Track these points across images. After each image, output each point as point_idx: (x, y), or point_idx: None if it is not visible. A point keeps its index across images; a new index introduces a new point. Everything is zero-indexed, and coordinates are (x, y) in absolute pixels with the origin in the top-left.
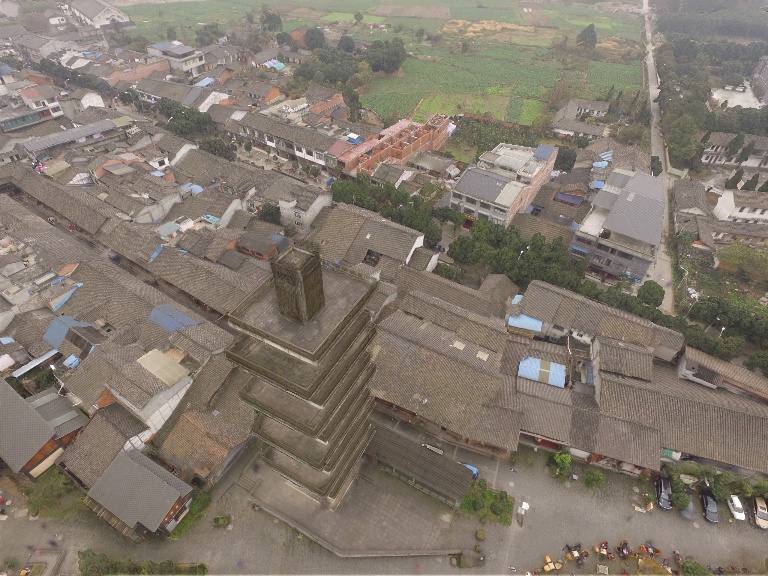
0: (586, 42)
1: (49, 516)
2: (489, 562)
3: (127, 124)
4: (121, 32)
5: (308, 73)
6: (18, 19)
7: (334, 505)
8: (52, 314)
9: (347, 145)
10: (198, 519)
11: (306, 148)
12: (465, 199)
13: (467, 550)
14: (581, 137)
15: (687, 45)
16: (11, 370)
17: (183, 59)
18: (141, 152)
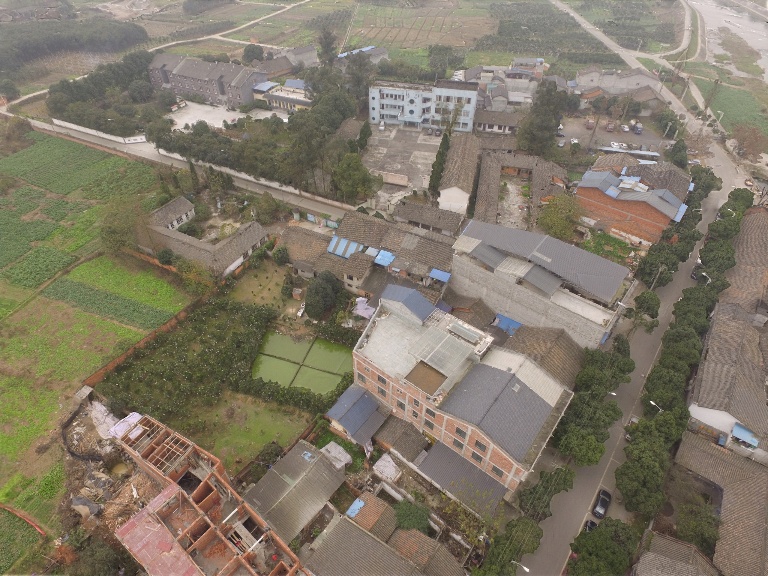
0: None
1: None
2: None
3: None
4: None
5: None
6: None
7: None
8: None
9: None
10: None
11: None
12: None
13: None
14: (278, 253)
15: (73, 88)
16: None
17: None
18: None
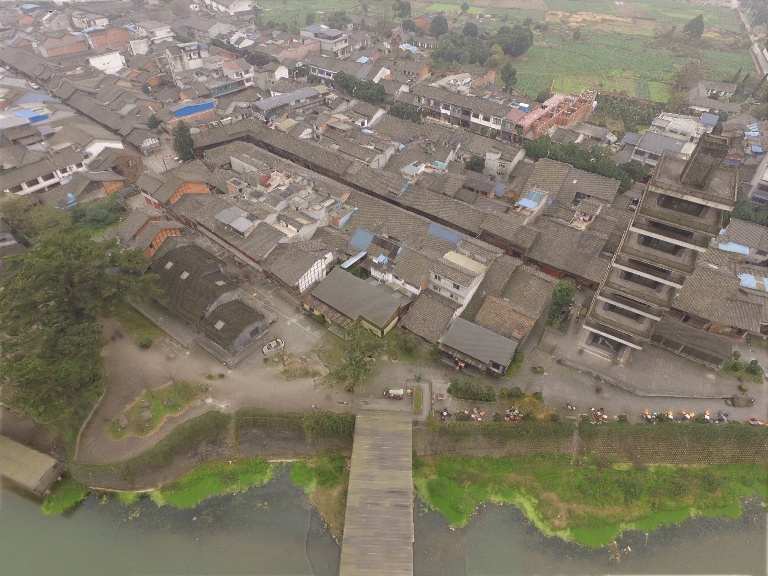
0: (692, 32)
1: (405, 360)
2: (756, 405)
3: (326, 91)
4: (259, 18)
5: (447, 55)
6: (167, 5)
7: (623, 362)
8: (337, 230)
9: (522, 112)
10: (519, 368)
11: (485, 114)
12: (647, 156)
13: (739, 394)
14: (721, 112)
15: None
16: (331, 266)
17: (334, 41)
18: (347, 114)
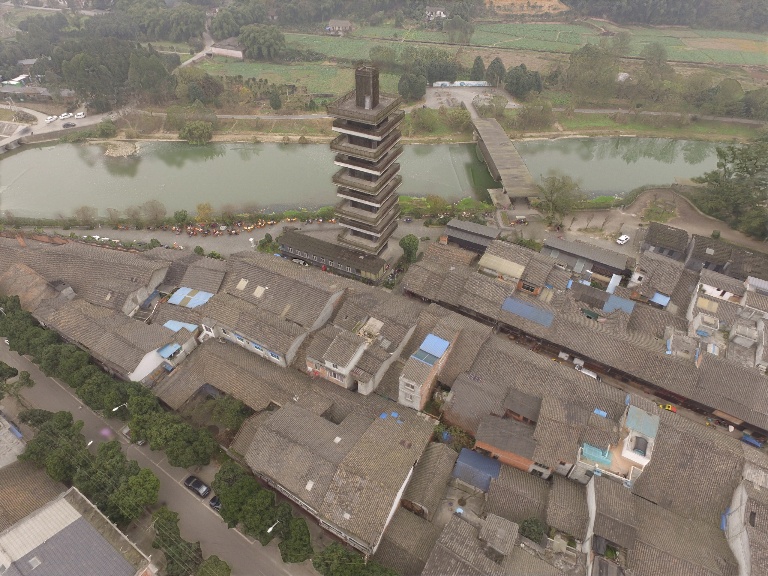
0: None
1: None
2: None
3: None
4: None
5: None
6: None
7: None
8: None
9: None
10: None
11: None
12: None
13: (291, 228)
14: None
15: None
16: None
17: None
18: None
